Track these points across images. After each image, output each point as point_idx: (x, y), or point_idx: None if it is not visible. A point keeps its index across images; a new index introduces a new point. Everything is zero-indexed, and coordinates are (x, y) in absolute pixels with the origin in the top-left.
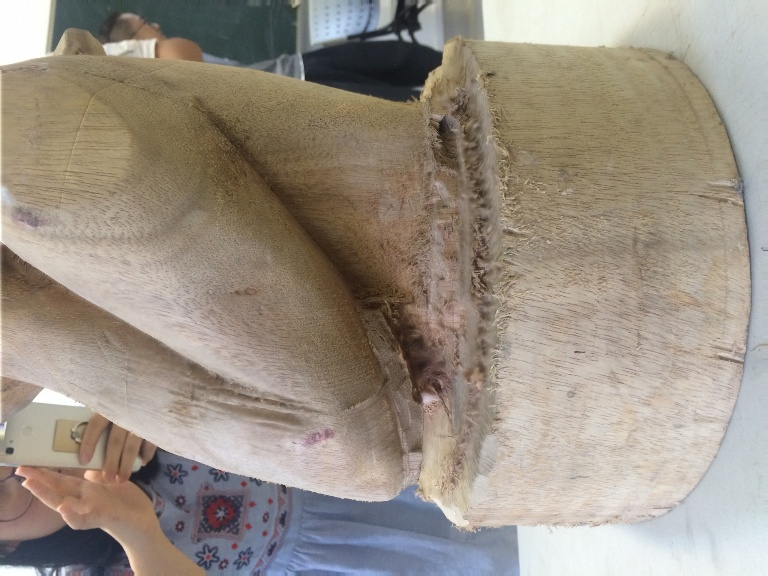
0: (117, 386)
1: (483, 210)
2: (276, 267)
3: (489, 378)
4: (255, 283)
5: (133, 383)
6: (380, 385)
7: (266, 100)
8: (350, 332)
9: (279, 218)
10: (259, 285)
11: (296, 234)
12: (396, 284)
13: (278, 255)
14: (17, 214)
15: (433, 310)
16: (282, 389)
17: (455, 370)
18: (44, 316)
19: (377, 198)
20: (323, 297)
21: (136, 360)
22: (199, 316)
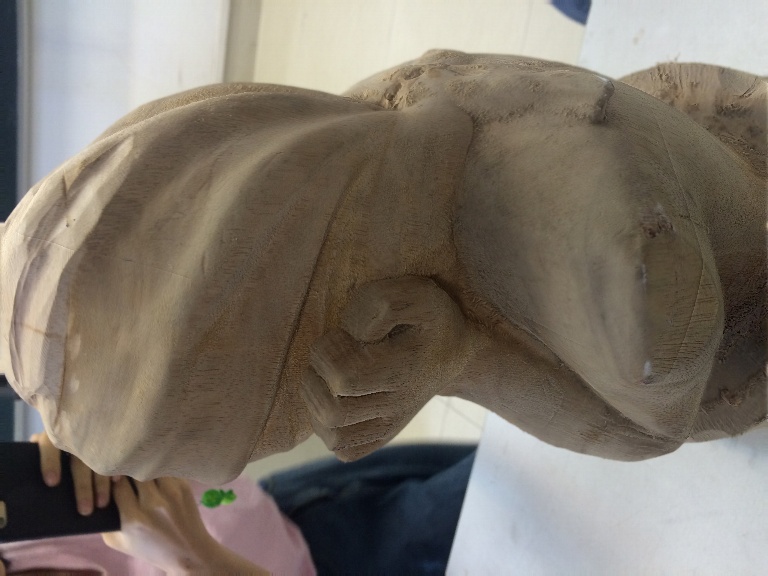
0: (546, 414)
1: None
2: (710, 366)
3: (763, 419)
4: None
5: (561, 415)
6: None
7: (721, 198)
8: None
9: None
10: None
11: None
12: None
13: None
14: (645, 379)
15: None
16: None
17: None
18: (506, 363)
19: None
20: None
21: (569, 400)
22: None
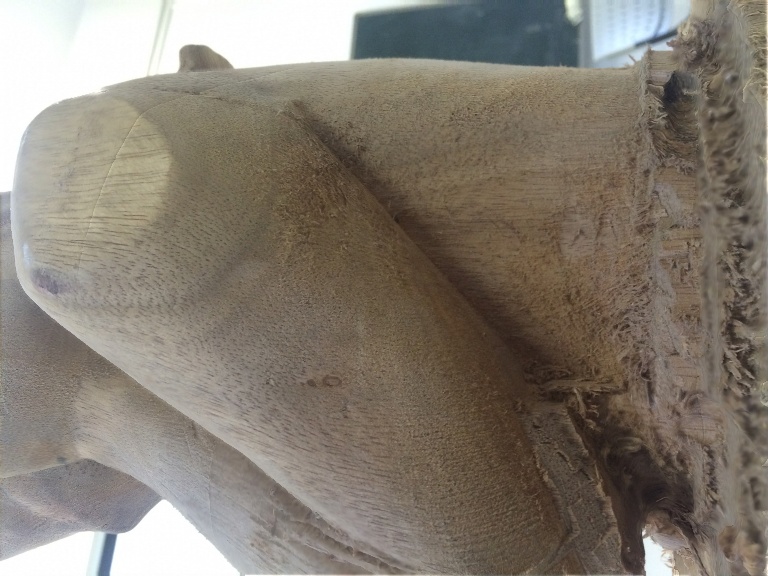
0: (201, 497)
1: (743, 229)
2: (372, 342)
3: (764, 570)
4: (339, 368)
5: (216, 497)
6: (556, 541)
7: (392, 93)
8: (499, 448)
9: (390, 263)
10: (345, 371)
11: (418, 286)
12: (596, 360)
13: (376, 322)
14: (36, 278)
15: (661, 407)
16: (380, 541)
17: (710, 513)
18: (138, 397)
19: (558, 221)
20: (451, 389)
21: (220, 465)
22: (258, 418)
